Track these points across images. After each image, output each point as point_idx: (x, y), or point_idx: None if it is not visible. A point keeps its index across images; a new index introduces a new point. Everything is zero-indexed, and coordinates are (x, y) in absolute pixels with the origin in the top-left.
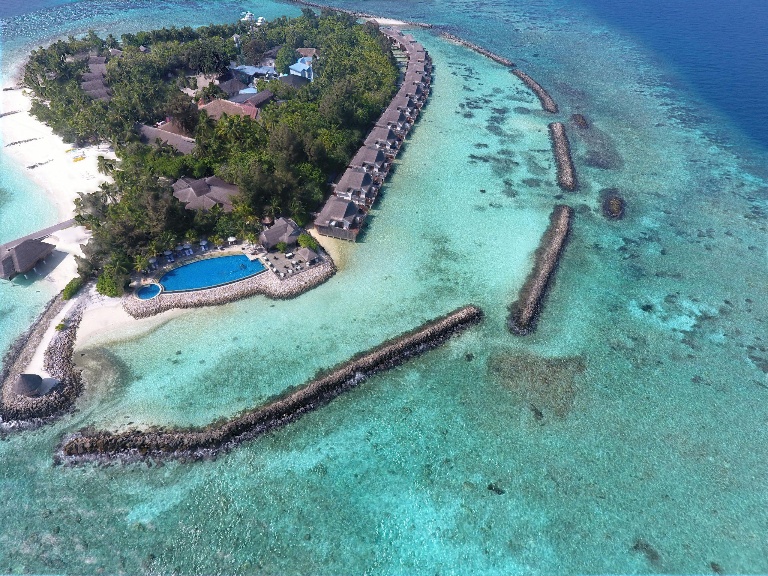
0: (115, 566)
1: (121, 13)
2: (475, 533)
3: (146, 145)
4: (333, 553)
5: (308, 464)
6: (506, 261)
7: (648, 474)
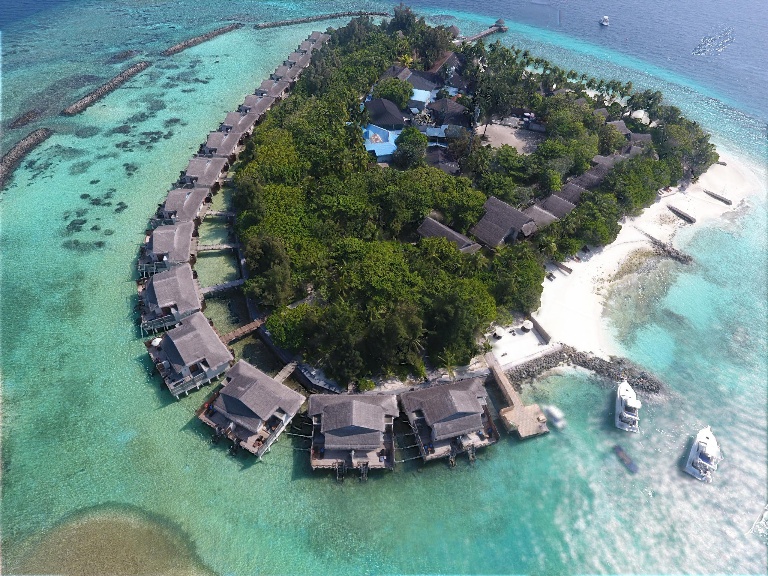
0: (363, 7)
1: None
2: (278, 6)
3: (449, 48)
4: (314, 6)
5: (322, 12)
6: (229, 38)
7: (222, 8)
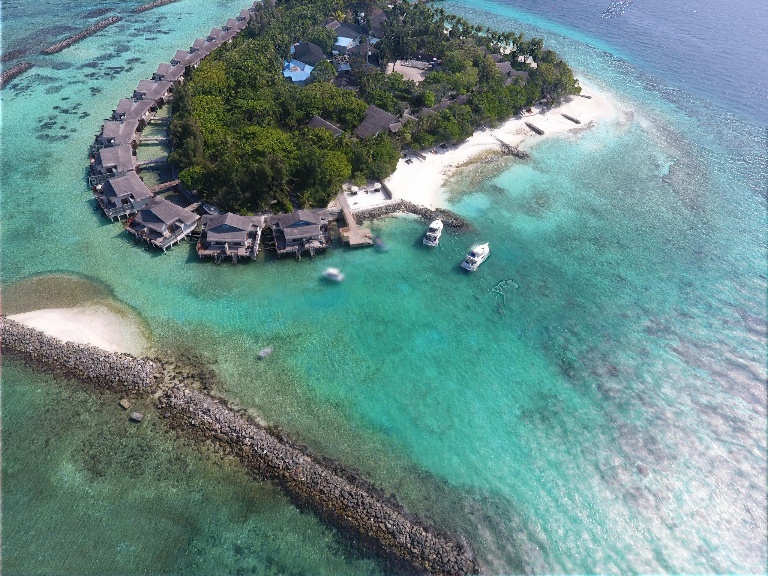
0: None
1: (767, 261)
2: None
3: (381, 8)
4: None
5: None
6: None
7: None
